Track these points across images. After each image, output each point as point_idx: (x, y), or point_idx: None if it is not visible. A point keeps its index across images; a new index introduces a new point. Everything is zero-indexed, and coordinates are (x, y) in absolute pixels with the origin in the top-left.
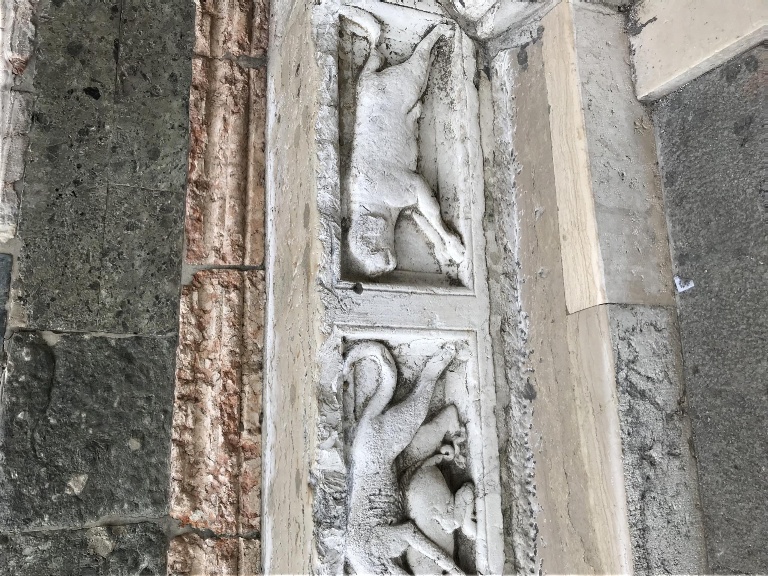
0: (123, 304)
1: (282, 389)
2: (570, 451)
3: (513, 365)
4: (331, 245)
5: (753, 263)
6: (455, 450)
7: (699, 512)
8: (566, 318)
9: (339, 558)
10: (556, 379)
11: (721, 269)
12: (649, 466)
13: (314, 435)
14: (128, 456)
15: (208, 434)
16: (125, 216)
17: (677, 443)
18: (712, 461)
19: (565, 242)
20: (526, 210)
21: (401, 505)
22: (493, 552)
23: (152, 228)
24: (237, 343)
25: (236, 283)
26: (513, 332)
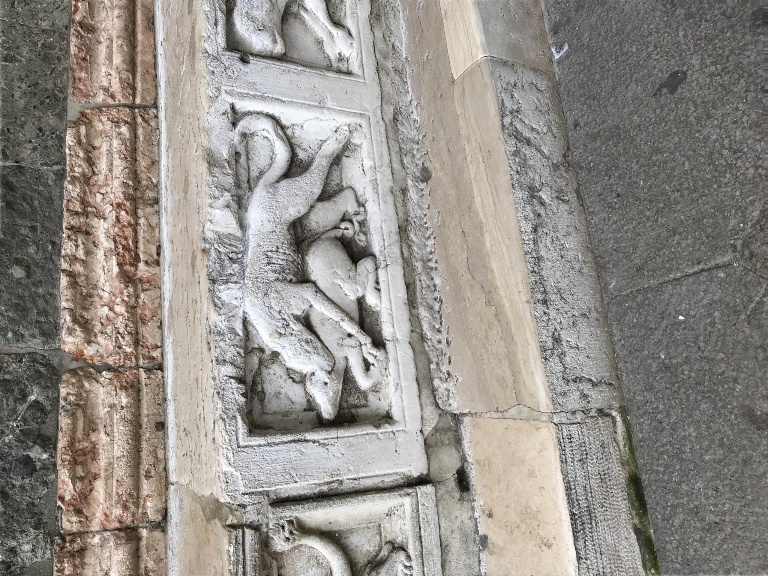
0: (2, 132)
1: (176, 197)
2: (465, 208)
3: (408, 152)
4: (215, 16)
5: (615, 0)
6: (355, 226)
7: (591, 254)
8: (453, 85)
9: (237, 312)
10: (448, 148)
11: (589, 20)
12: (539, 205)
13: (206, 196)
14: (12, 283)
15: (101, 266)
16: (3, 48)
17: (565, 191)
18: (598, 201)
19: (446, 15)
20: (410, 7)
21: (301, 268)
22: (399, 320)
23: (33, 62)
24: (130, 175)
25: (127, 119)
26: (406, 121)
